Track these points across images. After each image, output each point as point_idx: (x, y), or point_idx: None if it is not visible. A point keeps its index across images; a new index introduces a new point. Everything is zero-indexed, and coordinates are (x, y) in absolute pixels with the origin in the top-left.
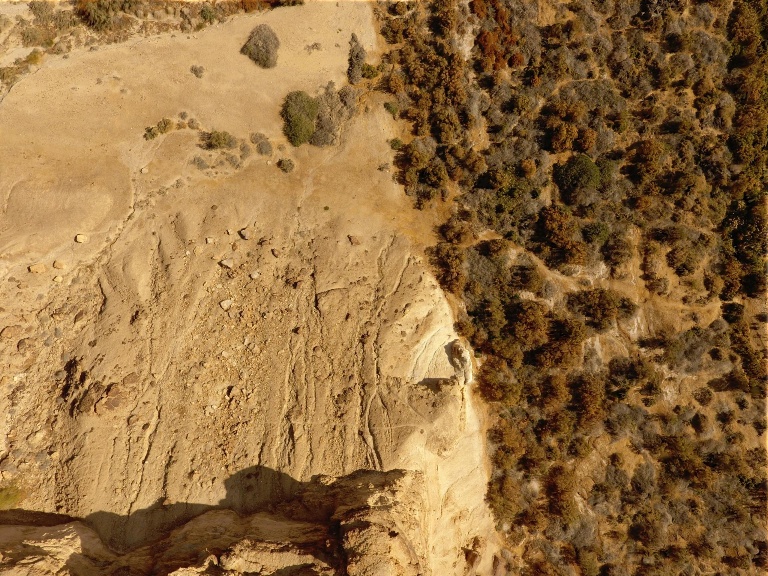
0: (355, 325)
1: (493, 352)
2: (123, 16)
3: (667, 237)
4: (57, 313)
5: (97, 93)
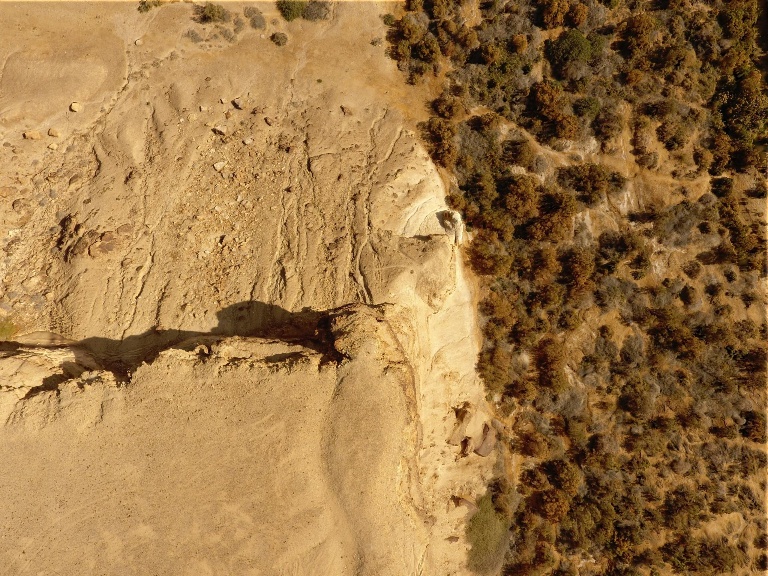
0: (347, 185)
1: (484, 224)
2: None
3: (657, 111)
4: (52, 176)
5: None
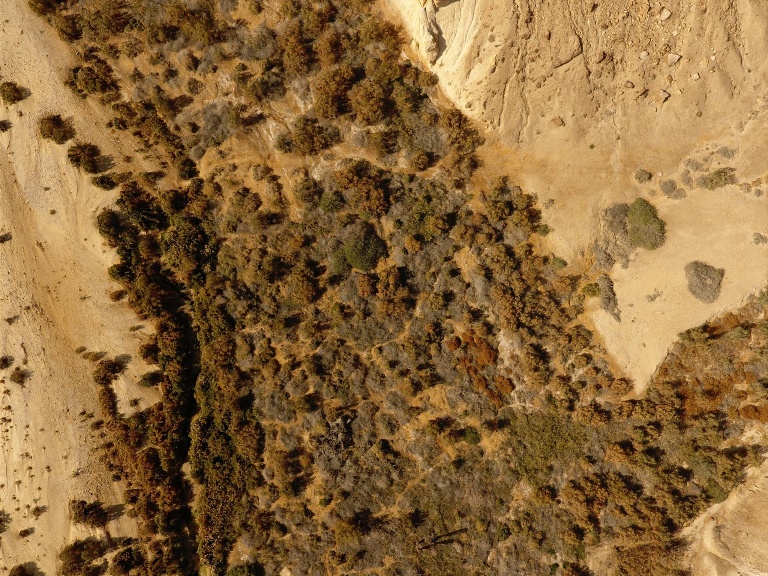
0: (540, 30)
1: None
2: None
3: (267, 218)
4: None
5: None
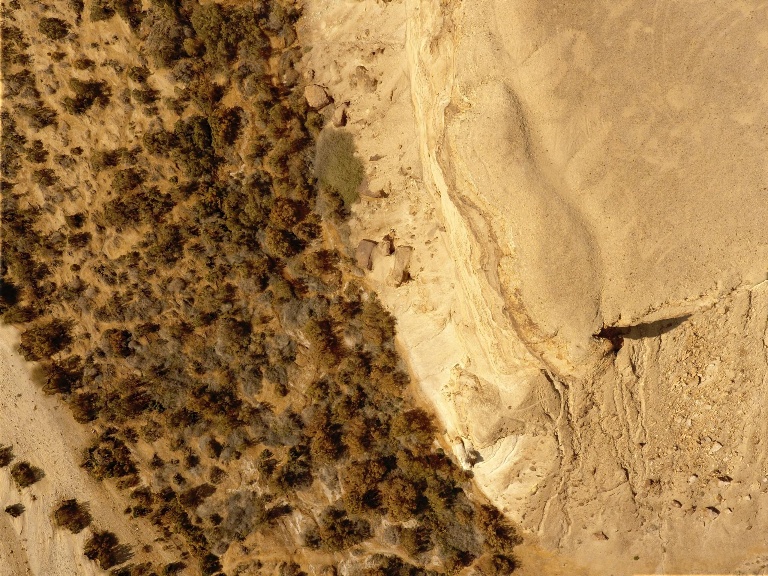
0: (585, 466)
1: (429, 461)
2: None
3: None
4: None
5: None
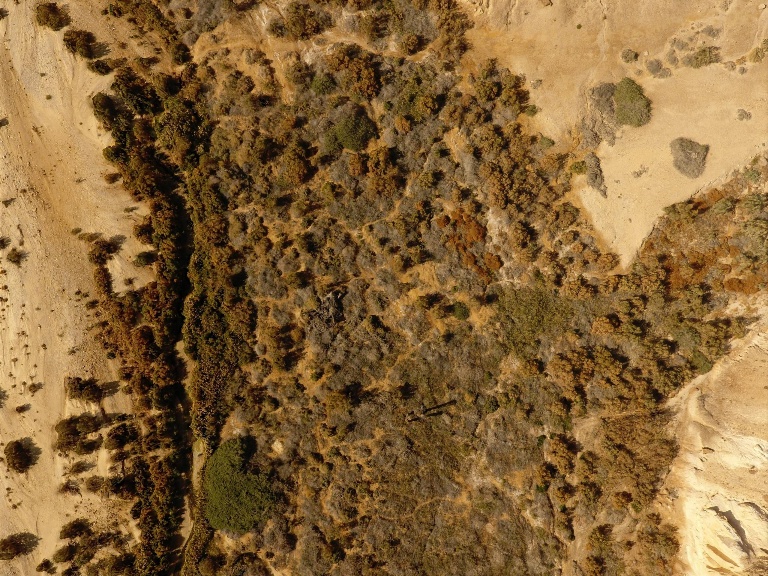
0: None
1: None
2: None
3: (259, 99)
4: None
5: None
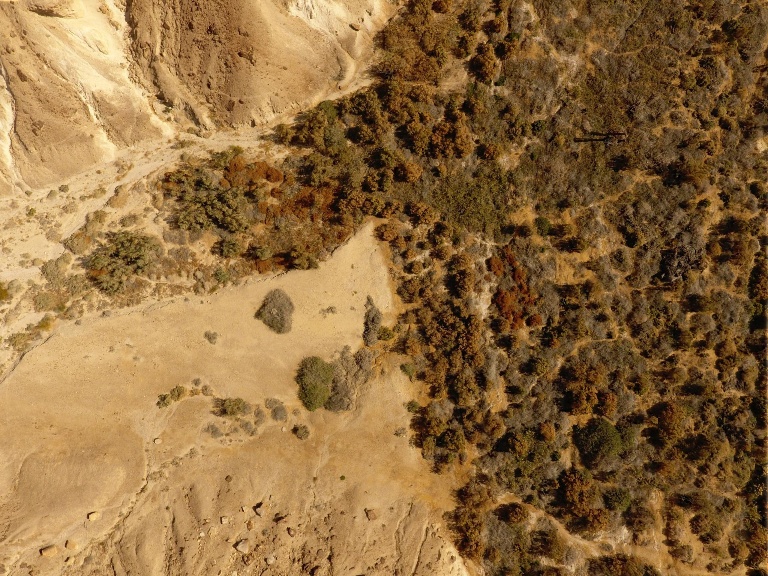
0: None
1: None
2: (136, 280)
3: (690, 505)
4: None
5: (110, 361)
